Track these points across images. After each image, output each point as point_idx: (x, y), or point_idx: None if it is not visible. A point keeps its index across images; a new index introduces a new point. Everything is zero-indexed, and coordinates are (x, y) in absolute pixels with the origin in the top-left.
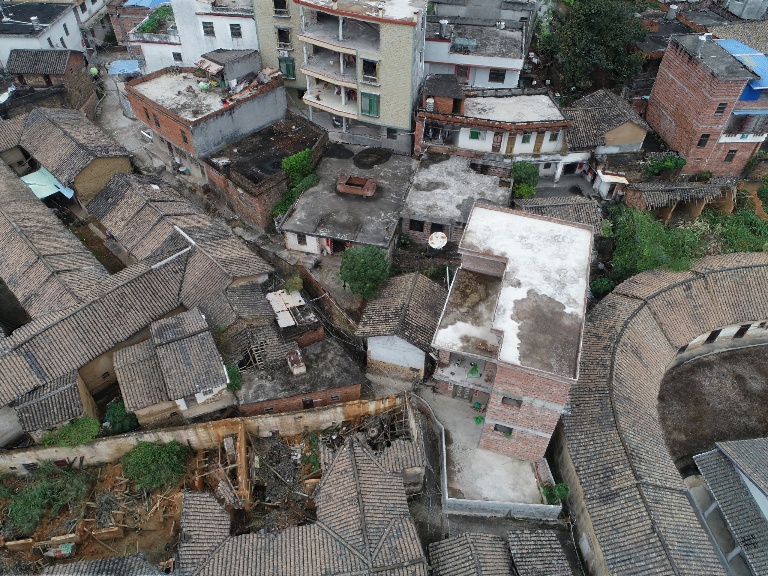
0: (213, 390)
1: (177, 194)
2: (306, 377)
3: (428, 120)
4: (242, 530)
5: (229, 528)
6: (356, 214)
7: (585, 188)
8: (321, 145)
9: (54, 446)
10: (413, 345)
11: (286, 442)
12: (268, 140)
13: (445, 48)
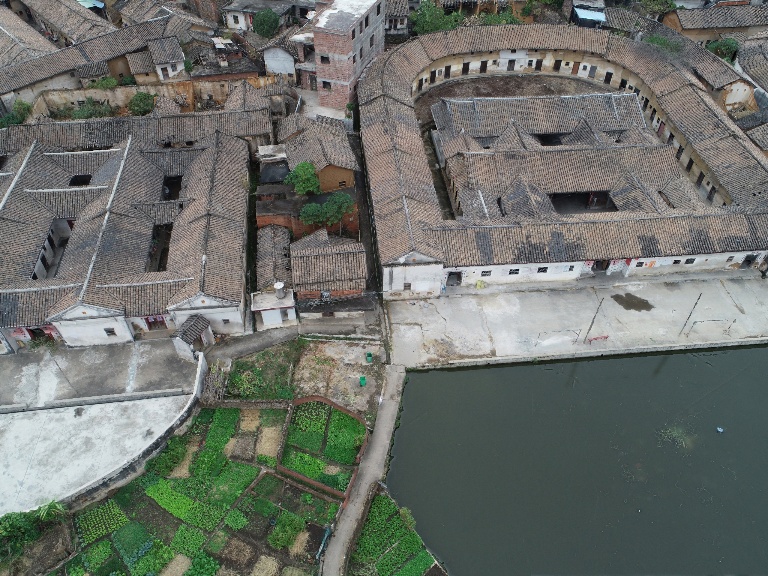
0: (177, 69)
1: (166, 2)
2: (228, 68)
3: None
4: None
5: (180, 111)
6: (267, 5)
7: (417, 7)
8: None
9: (94, 88)
10: (286, 53)
11: (216, 103)
12: None
13: None
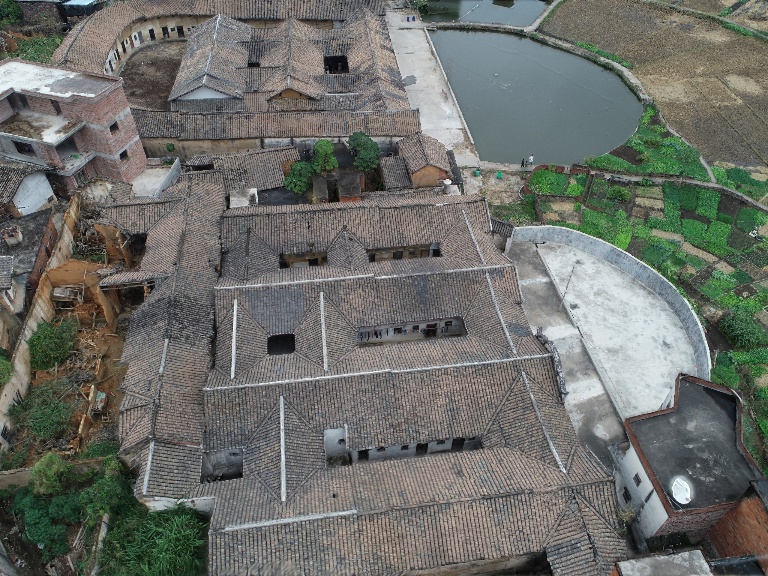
0: None
1: None
2: (27, 237)
3: None
4: (130, 302)
5: None
6: None
7: None
8: None
9: (1, 391)
10: None
11: None
12: None
13: None
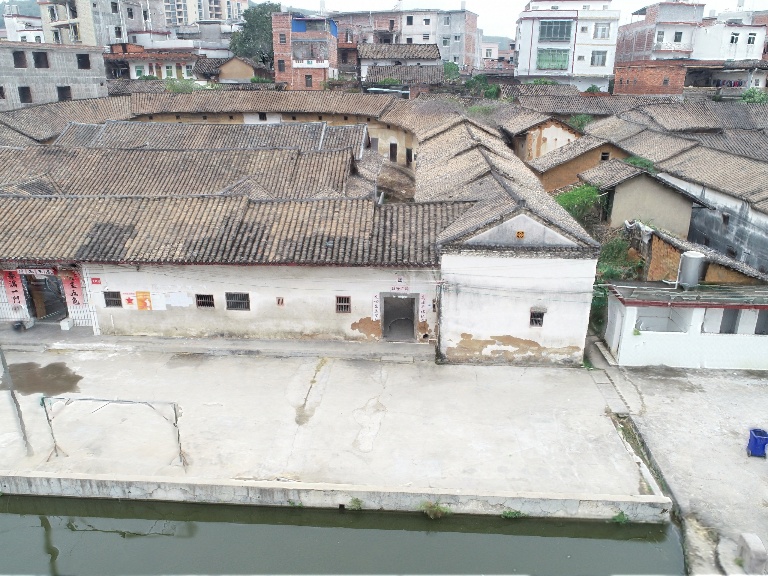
0: None
1: None
2: None
3: (104, 59)
4: None
5: None
6: None
7: None
8: None
9: None
10: None
11: None
12: None
13: (149, 38)
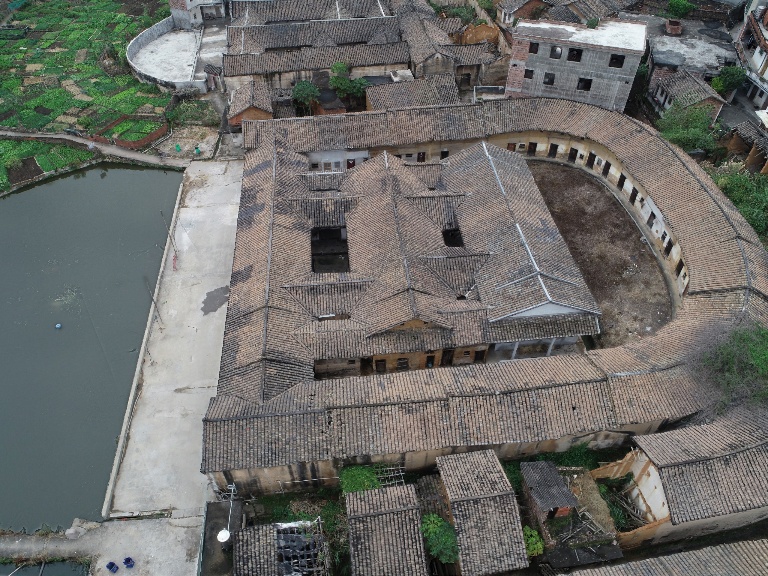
0: None
1: None
2: None
3: None
4: None
5: (450, 33)
6: None
7: None
8: (713, 16)
9: None
10: None
11: None
12: (706, 4)
13: None
